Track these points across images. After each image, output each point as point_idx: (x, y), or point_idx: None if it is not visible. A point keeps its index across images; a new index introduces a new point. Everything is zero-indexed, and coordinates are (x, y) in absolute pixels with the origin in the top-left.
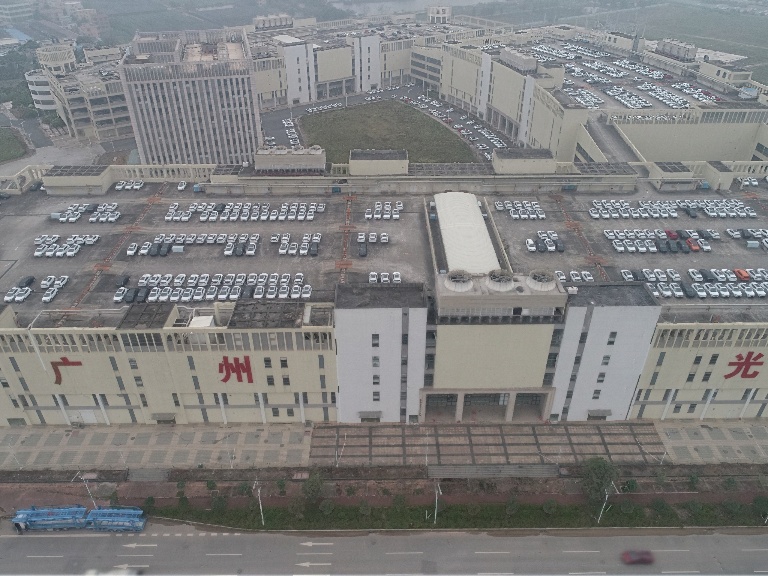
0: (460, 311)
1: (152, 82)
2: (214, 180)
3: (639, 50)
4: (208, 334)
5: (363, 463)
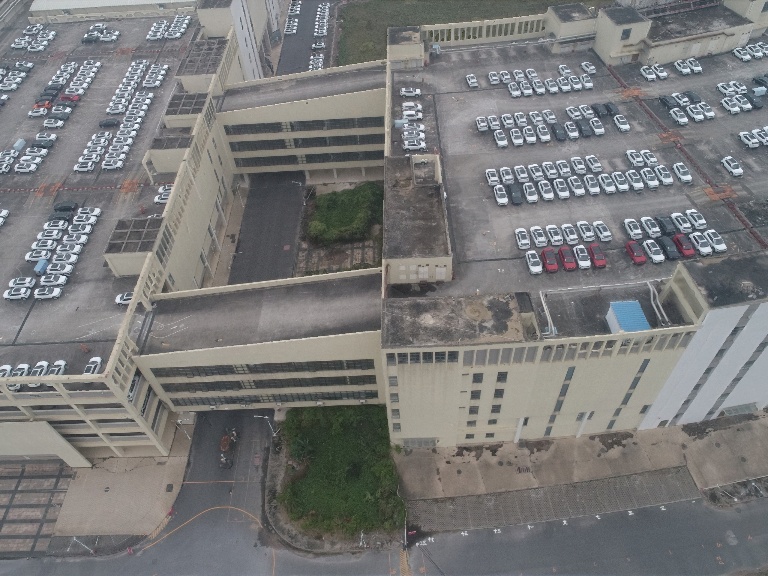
0: None
1: None
2: None
3: None
4: None
5: None
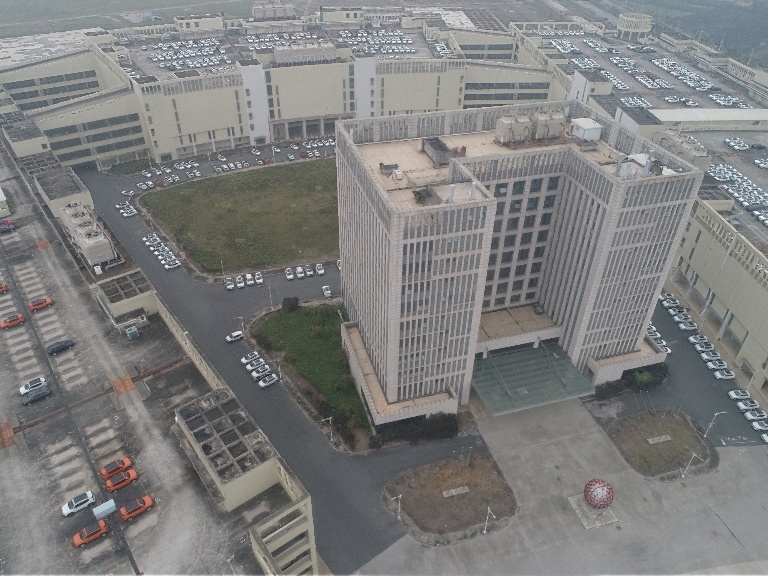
0: None
1: None
2: None
3: None
4: None
5: None
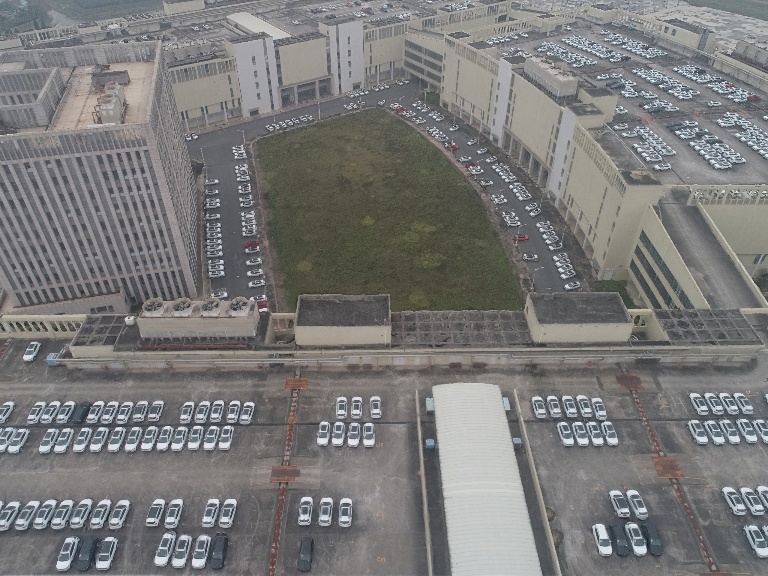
0: None
1: None
2: (77, 353)
3: (706, 48)
4: None
5: None
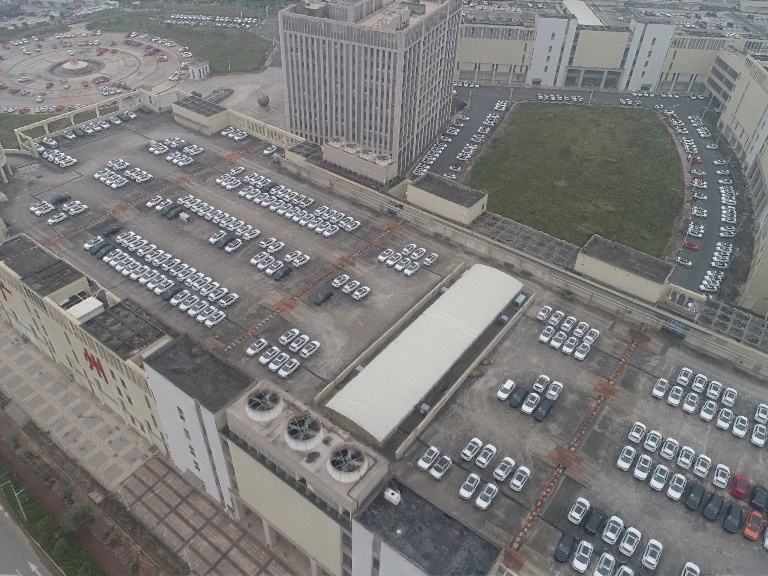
0: (247, 439)
1: (305, 35)
2: (288, 156)
3: None
4: (69, 322)
5: (148, 523)
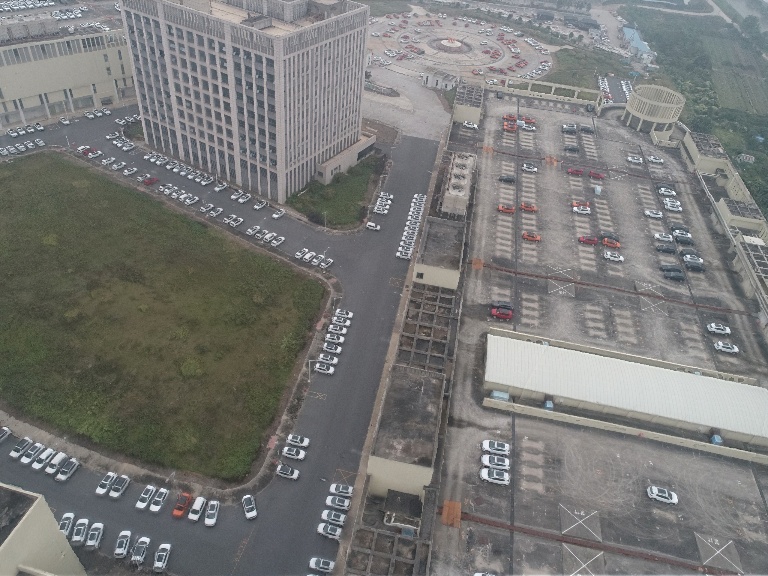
0: None
1: None
2: None
3: None
4: None
5: None
